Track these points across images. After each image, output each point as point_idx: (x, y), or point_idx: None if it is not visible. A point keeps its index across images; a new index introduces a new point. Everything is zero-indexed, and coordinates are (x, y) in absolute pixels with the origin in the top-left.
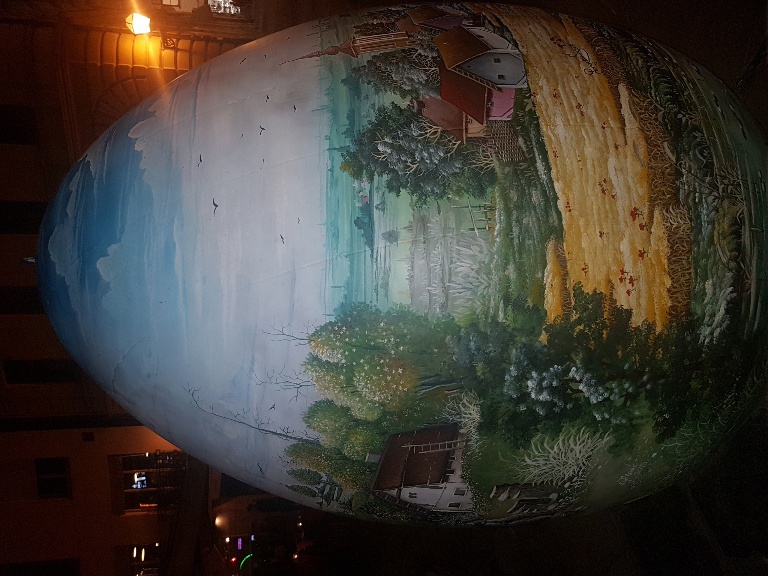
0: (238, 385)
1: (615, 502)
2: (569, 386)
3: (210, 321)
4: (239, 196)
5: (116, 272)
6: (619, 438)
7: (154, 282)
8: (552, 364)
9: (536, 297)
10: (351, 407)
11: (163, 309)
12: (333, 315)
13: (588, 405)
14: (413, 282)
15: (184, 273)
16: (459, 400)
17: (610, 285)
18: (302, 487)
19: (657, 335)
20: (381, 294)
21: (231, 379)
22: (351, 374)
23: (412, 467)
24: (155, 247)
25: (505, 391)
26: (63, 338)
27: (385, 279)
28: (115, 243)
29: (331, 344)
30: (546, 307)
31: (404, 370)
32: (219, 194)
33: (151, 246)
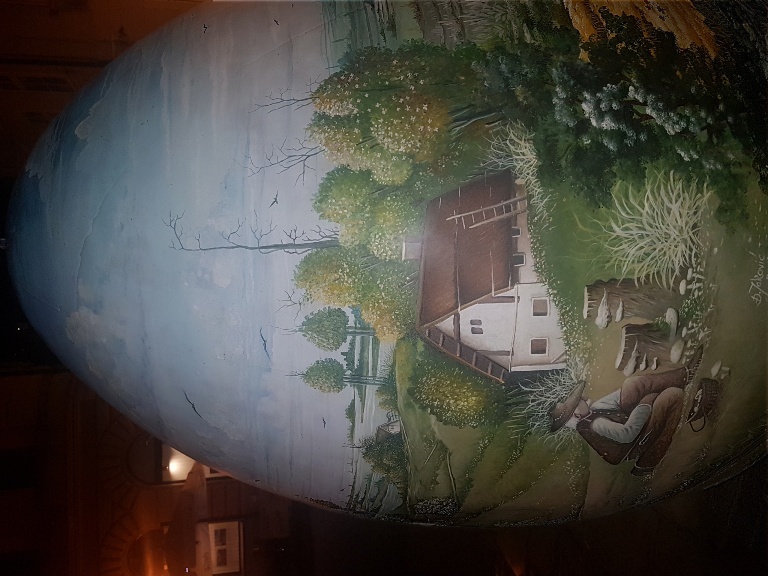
0: (231, 185)
1: (763, 376)
2: (633, 110)
3: (197, 119)
4: (230, 14)
5: (95, 124)
6: (723, 196)
7: (136, 109)
8: (604, 83)
9: (561, 19)
10: (372, 169)
11: (144, 132)
12: (338, 66)
13: (666, 137)
14: (422, 20)
15: (170, 86)
16: (504, 135)
17: (638, 11)
18: (323, 364)
19: (713, 60)
20: (389, 35)
21: (222, 180)
22: (367, 124)
23: (466, 258)
24: (140, 81)
25: (558, 118)
26: (25, 275)
27: (391, 23)
28: (97, 101)
29: (339, 96)
30: (576, 27)
31: (430, 106)
32: (210, 21)
33: (136, 82)
